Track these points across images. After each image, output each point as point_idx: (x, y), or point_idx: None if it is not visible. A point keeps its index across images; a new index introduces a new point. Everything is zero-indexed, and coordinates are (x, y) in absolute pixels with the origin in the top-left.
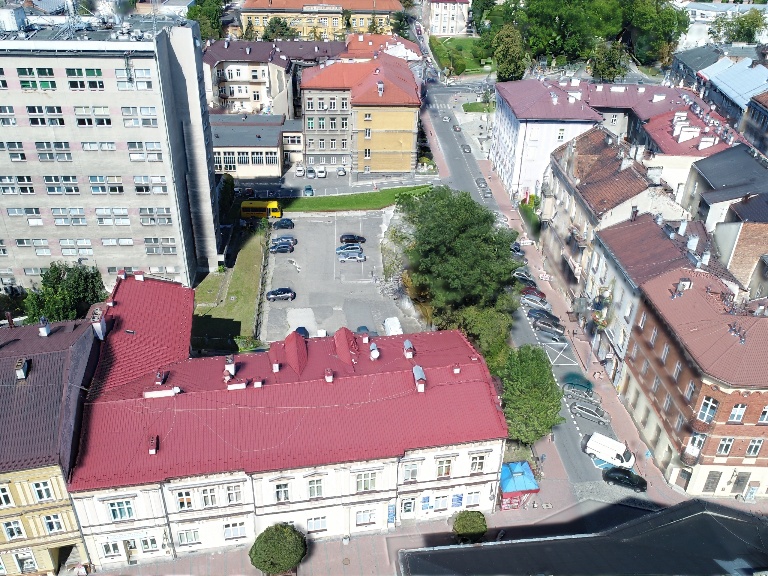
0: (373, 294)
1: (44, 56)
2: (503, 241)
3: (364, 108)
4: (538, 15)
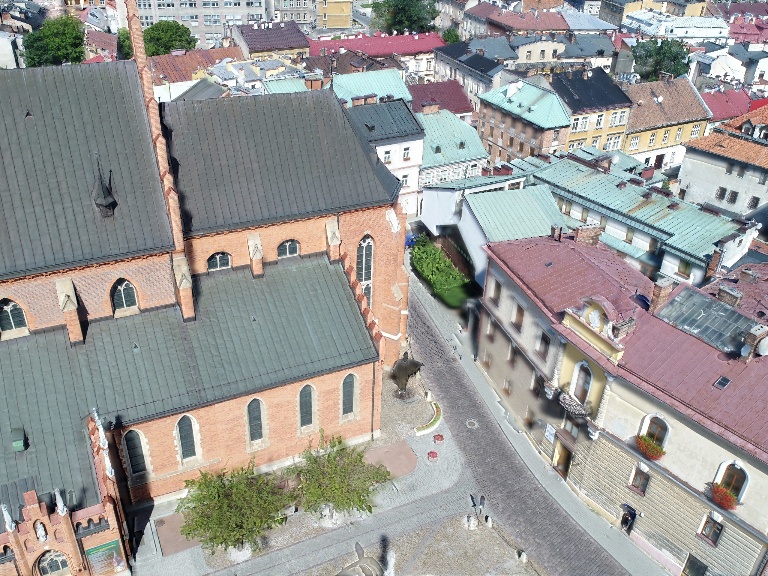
0: None
1: None
2: (431, 3)
3: None
4: None
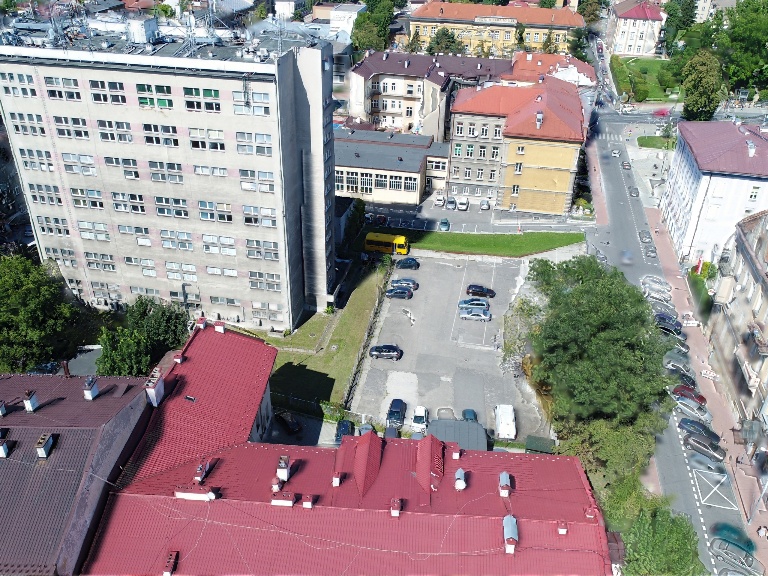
0: (491, 366)
1: (163, 73)
2: (654, 349)
3: (517, 140)
4: (744, 39)
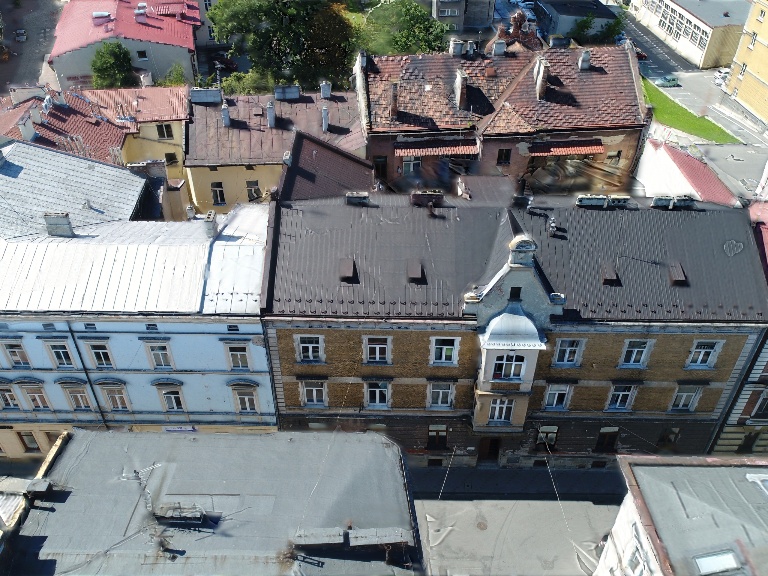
0: None
1: None
2: None
3: None
4: None
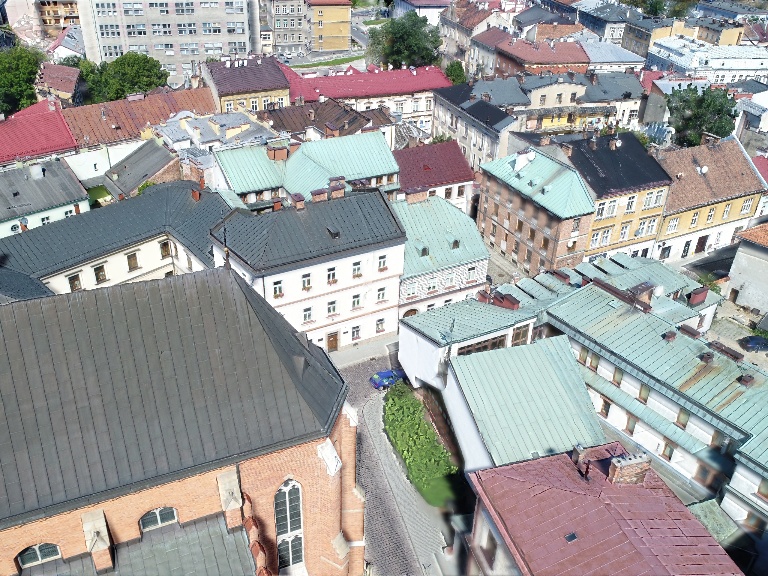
0: None
1: None
2: (433, 31)
3: (318, 7)
4: None
